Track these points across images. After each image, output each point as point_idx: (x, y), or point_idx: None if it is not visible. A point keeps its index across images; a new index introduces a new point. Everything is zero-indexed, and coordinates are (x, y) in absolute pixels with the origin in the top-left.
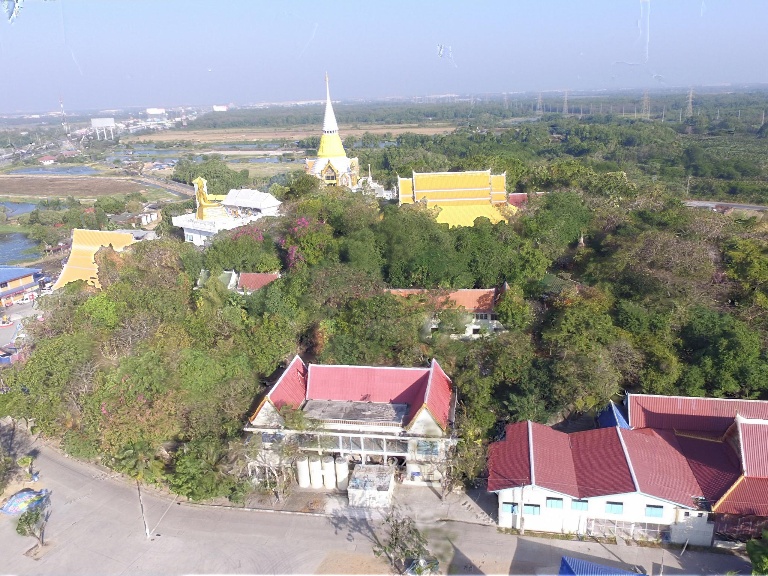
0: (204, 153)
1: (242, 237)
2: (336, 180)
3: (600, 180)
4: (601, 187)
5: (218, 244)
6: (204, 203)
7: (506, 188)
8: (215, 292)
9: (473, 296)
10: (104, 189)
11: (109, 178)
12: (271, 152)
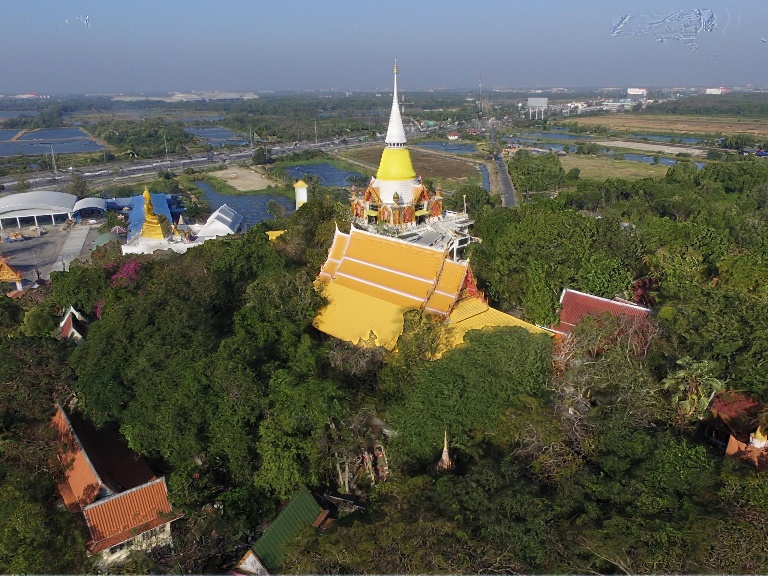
0: (604, 142)
1: (91, 270)
2: (378, 212)
3: None
4: (712, 340)
5: (72, 272)
6: (147, 217)
7: None
8: (30, 327)
9: (86, 477)
10: (440, 171)
11: (467, 160)
12: (677, 149)
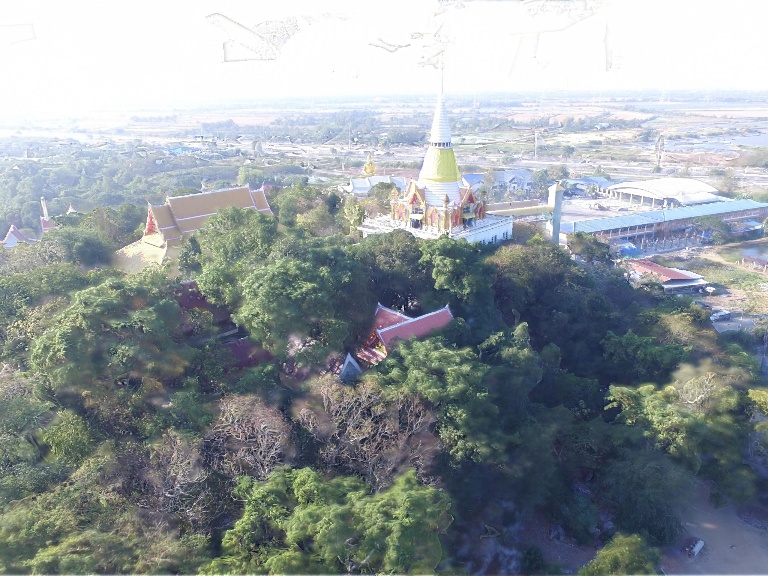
0: None
1: None
2: None
3: None
4: None
5: None
6: None
7: (185, 255)
8: None
9: None
10: None
11: None
12: None
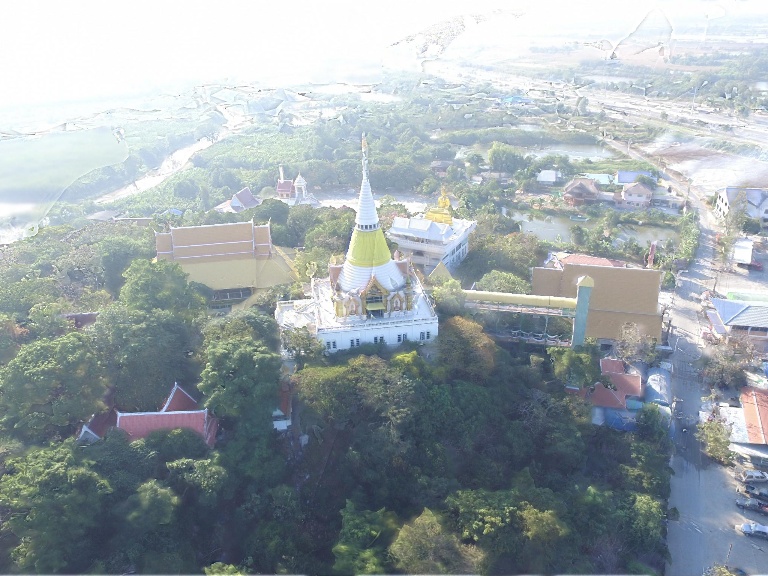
0: None
1: None
2: None
3: (3, 290)
4: None
5: None
6: None
7: None
8: None
9: None
10: None
11: None
12: None
